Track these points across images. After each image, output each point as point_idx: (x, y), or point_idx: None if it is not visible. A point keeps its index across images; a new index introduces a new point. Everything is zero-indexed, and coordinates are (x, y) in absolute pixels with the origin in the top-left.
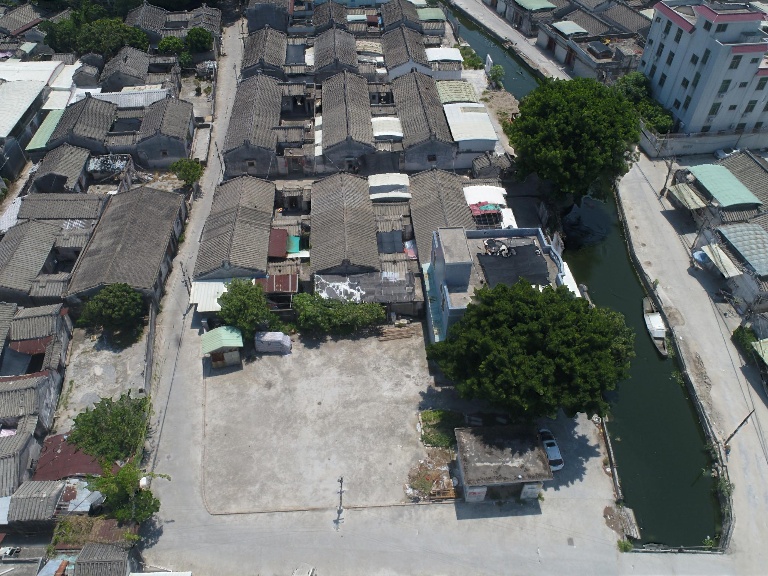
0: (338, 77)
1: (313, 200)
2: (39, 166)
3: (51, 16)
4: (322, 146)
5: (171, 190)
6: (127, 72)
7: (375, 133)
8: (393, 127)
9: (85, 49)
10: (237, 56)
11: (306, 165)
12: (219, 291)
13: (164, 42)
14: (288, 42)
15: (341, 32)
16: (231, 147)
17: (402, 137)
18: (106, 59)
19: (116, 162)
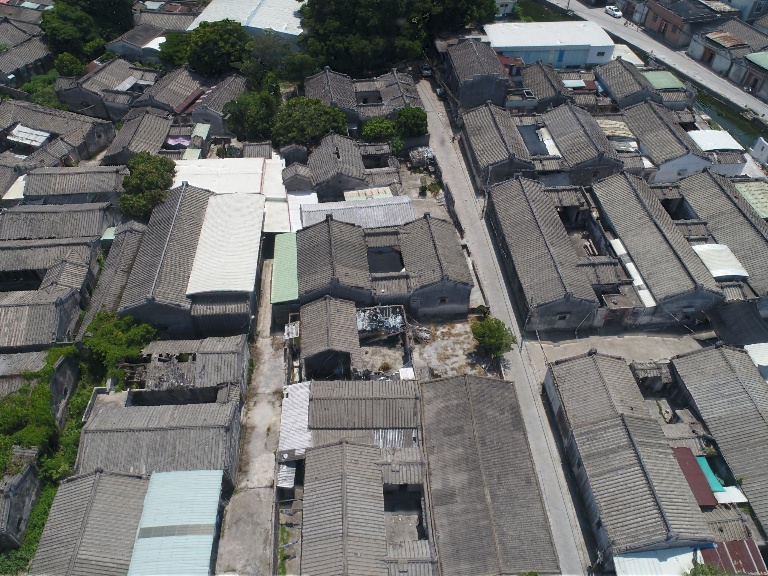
0: (616, 180)
1: (693, 390)
2: (298, 330)
3: (210, 84)
4: (653, 293)
5: (463, 355)
6: (348, 173)
7: (713, 272)
8: (730, 261)
9: (286, 139)
10: (443, 135)
11: (629, 316)
12: (659, 575)
13: (374, 127)
14: (515, 122)
15: (577, 109)
16: (541, 298)
17: (746, 276)
18: (307, 149)
19: (389, 317)
